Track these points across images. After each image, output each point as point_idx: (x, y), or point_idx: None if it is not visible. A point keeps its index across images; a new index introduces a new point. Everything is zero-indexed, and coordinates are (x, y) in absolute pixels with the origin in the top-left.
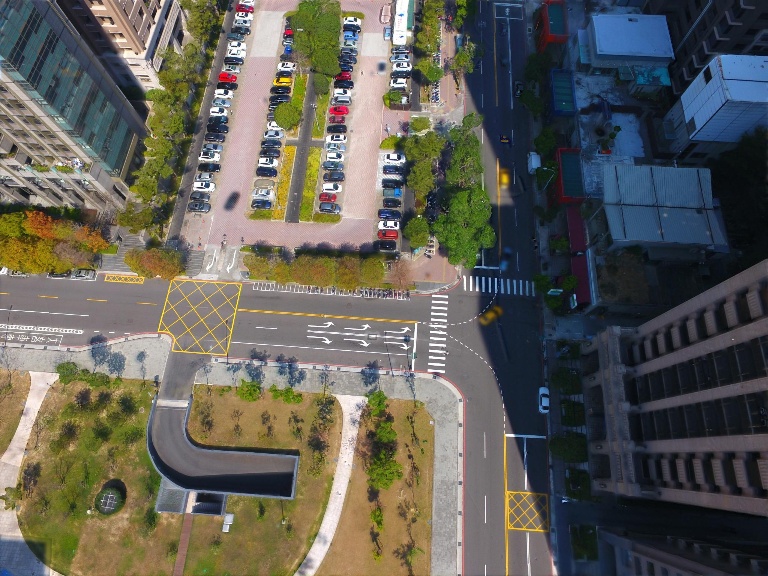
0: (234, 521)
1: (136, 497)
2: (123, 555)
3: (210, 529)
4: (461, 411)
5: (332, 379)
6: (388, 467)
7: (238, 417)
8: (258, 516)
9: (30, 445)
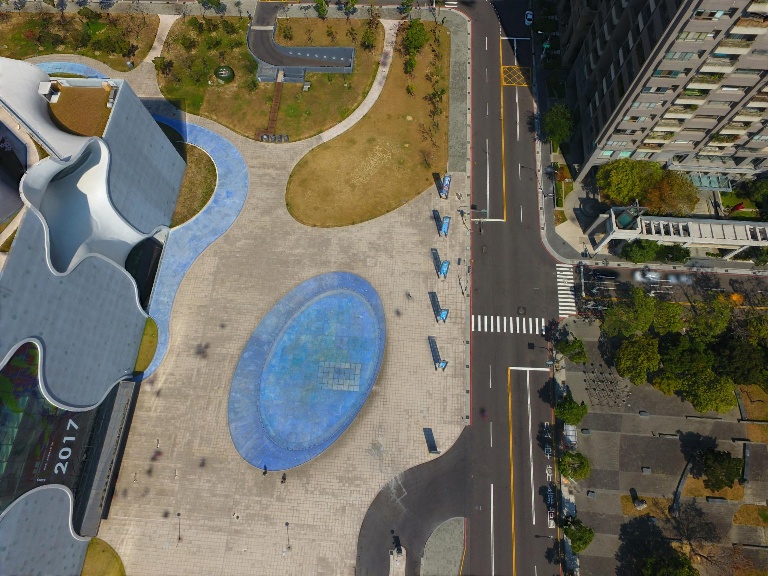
0: (311, 85)
1: (241, 76)
2: (235, 104)
3: (294, 90)
4: (469, 26)
5: (376, 11)
6: (419, 29)
7: (310, 33)
8: (328, 82)
9: (163, 53)
